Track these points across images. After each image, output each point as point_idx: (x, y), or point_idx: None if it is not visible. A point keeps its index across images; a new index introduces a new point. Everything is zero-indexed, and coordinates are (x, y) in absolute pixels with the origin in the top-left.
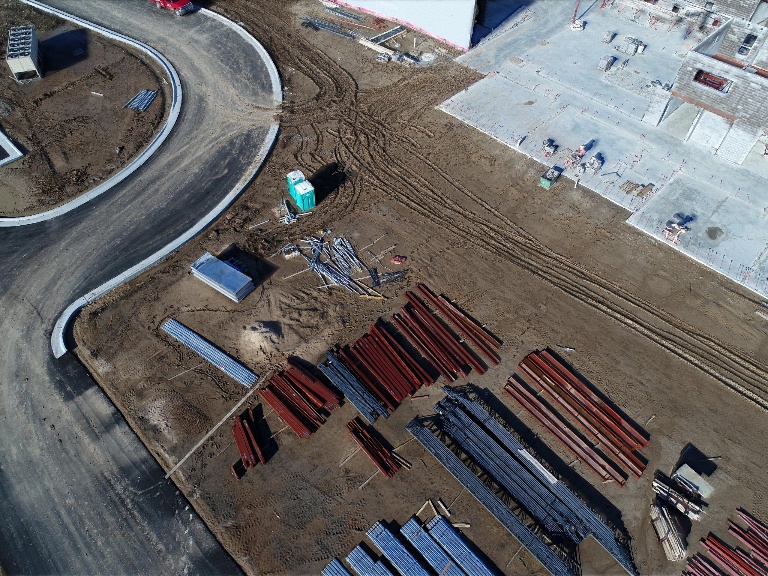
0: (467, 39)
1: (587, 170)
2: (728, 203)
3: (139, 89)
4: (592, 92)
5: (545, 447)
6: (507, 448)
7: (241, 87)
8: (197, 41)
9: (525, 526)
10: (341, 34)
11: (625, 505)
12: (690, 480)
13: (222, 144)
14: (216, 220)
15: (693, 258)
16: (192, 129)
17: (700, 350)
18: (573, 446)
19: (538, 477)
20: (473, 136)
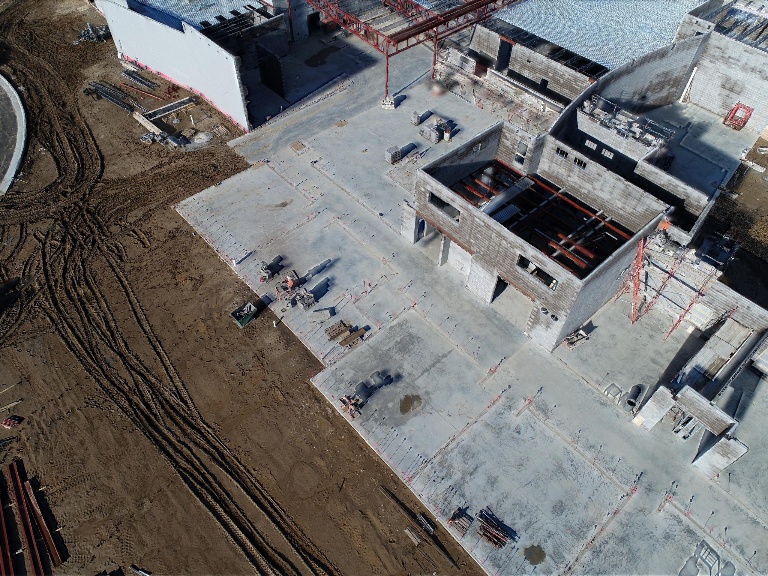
0: (244, 119)
1: (298, 304)
2: (448, 359)
3: None
4: (363, 192)
5: None
6: None
7: None
8: None
9: None
10: (119, 105)
11: None
12: None
13: None
14: None
15: (365, 440)
16: None
17: None
18: None
19: None
20: (194, 248)
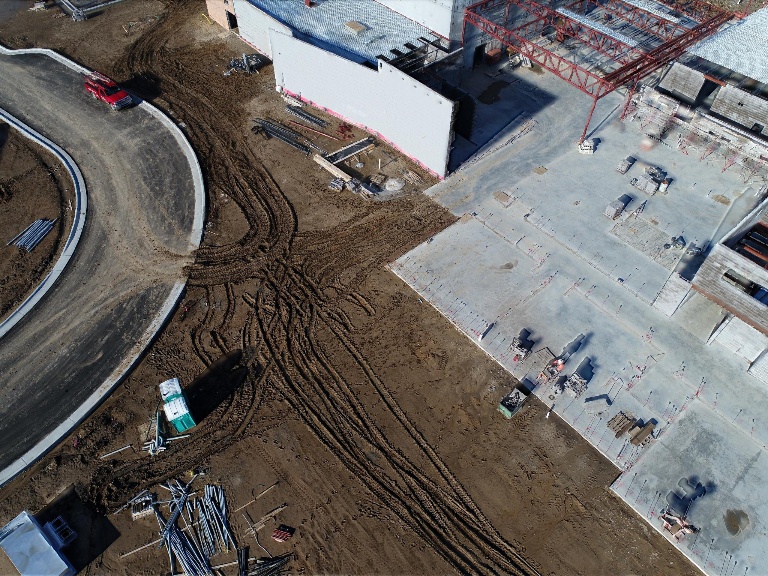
0: (442, 166)
1: (567, 390)
2: (760, 463)
3: (36, 217)
4: (592, 252)
5: None
6: None
7: (156, 220)
8: (124, 148)
9: None
10: (295, 146)
11: None
12: None
13: (108, 310)
14: (64, 439)
15: (700, 569)
16: (79, 283)
17: None
18: None
19: None
20: (425, 317)
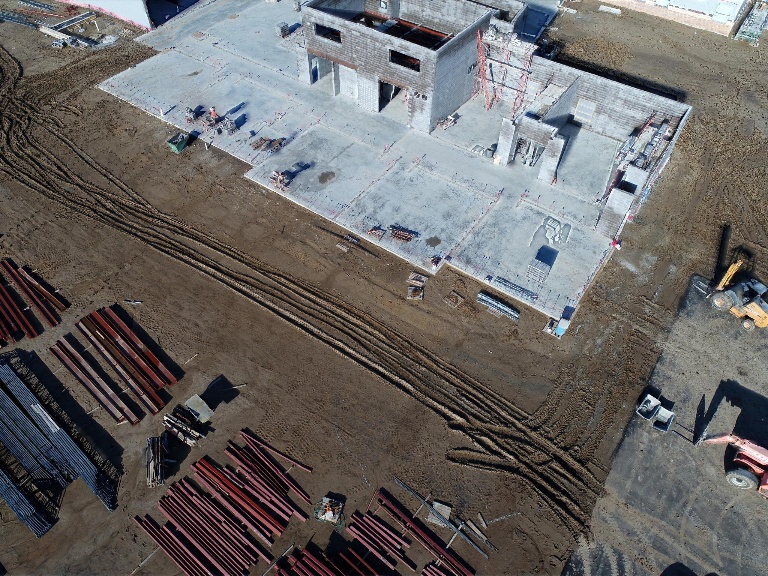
0: (146, 18)
1: (223, 131)
2: (351, 148)
3: None
4: (262, 58)
5: (71, 399)
6: (21, 405)
7: None
8: None
9: (4, 477)
10: (24, 24)
11: (131, 443)
12: (194, 409)
13: None
14: None
15: (296, 202)
16: None
17: (268, 287)
18: (98, 394)
19: (41, 428)
20: (123, 110)
